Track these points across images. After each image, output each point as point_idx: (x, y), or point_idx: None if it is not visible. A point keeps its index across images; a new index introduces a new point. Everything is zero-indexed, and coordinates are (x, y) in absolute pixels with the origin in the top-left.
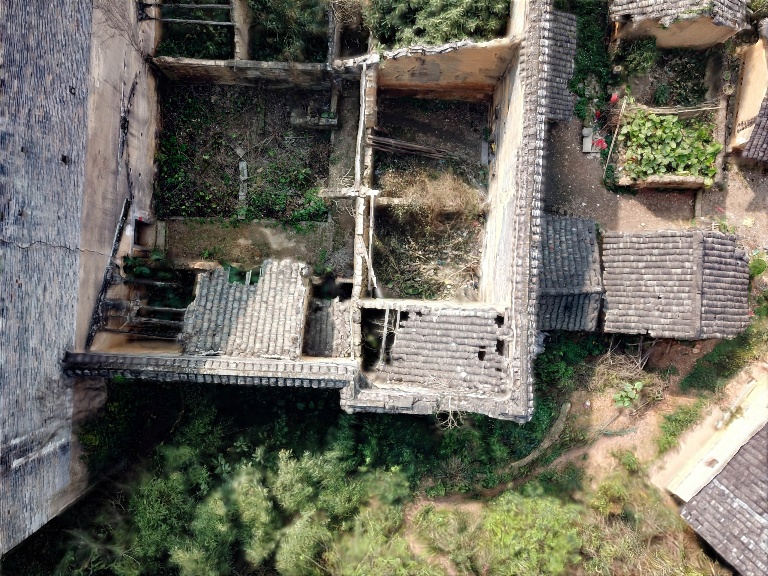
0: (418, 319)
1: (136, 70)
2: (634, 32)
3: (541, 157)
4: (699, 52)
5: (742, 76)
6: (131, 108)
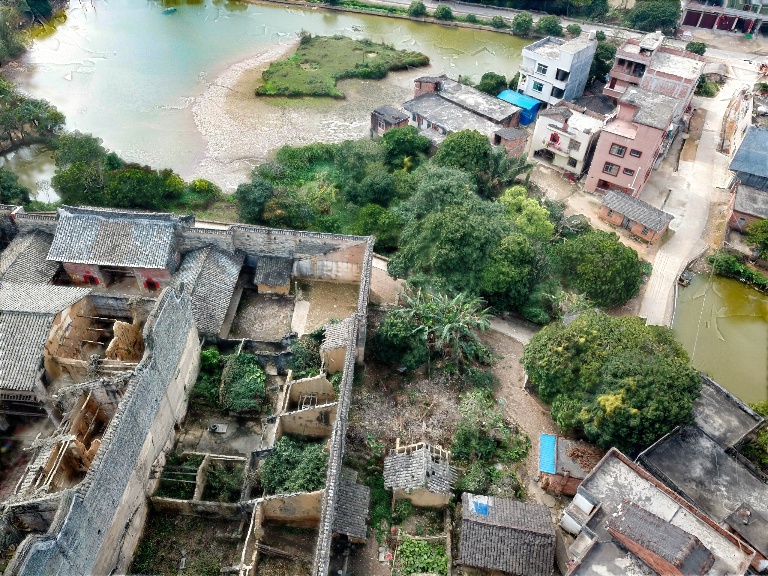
0: None
1: (141, 502)
2: (398, 496)
3: (326, 542)
4: (439, 509)
5: (462, 522)
6: (132, 520)
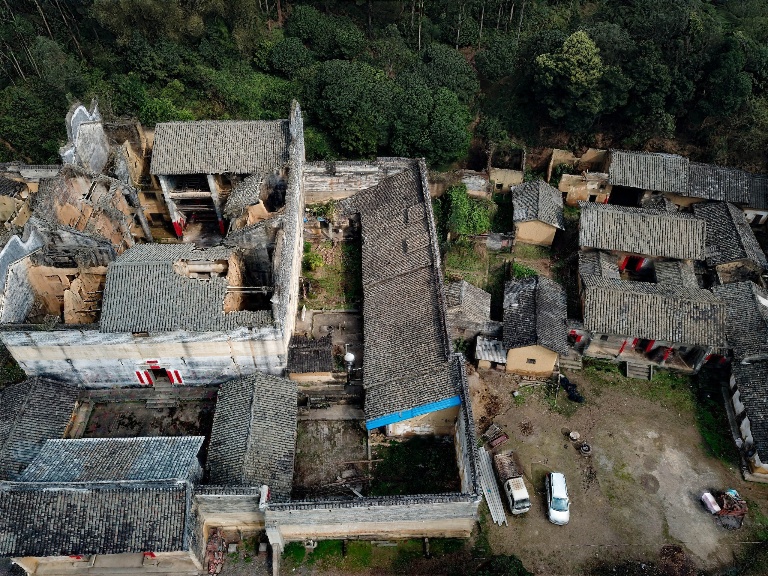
0: (2, 192)
1: None
2: None
3: None
4: None
5: None
6: None
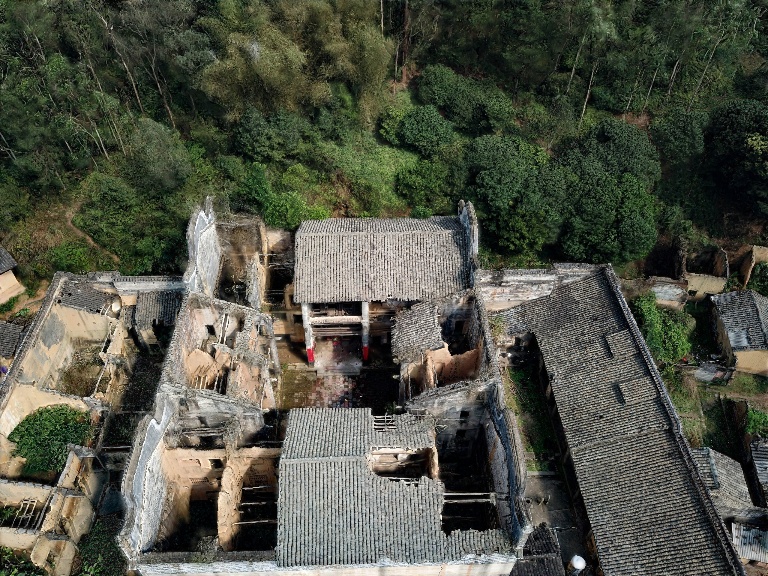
0: (92, 309)
1: None
2: None
3: None
4: None
5: None
6: None
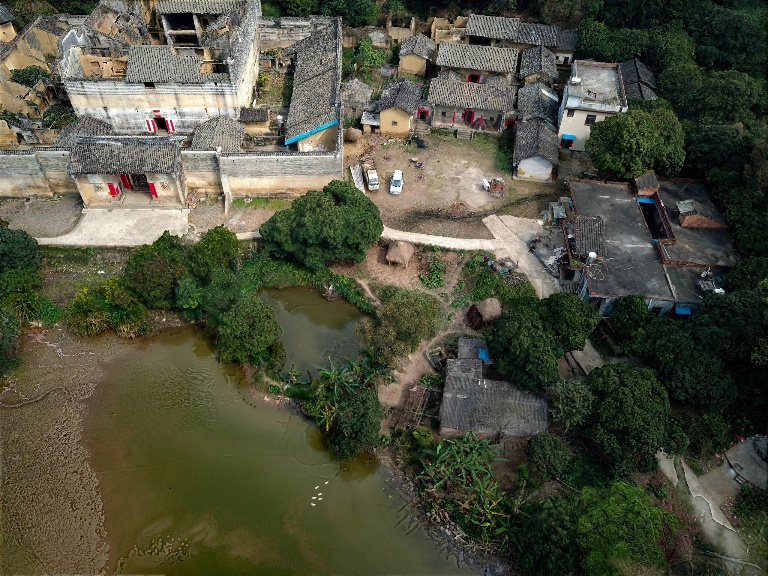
0: (55, 33)
1: None
2: None
3: None
4: None
5: None
6: None
